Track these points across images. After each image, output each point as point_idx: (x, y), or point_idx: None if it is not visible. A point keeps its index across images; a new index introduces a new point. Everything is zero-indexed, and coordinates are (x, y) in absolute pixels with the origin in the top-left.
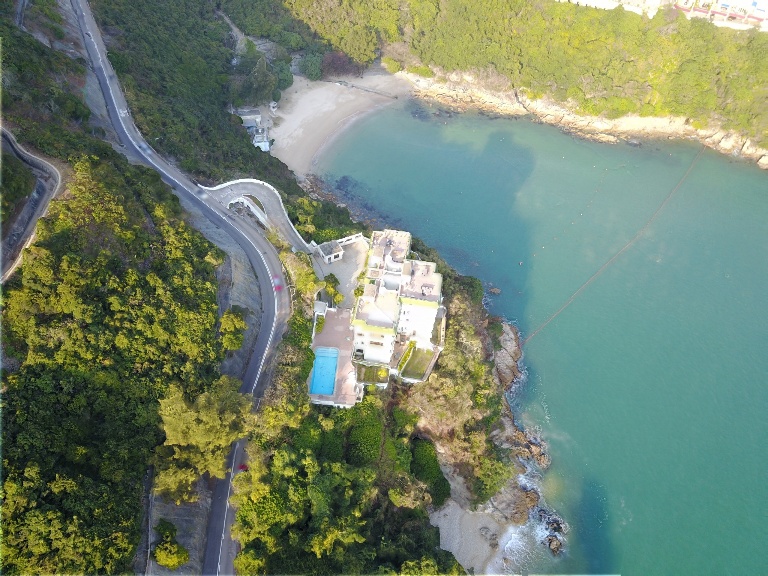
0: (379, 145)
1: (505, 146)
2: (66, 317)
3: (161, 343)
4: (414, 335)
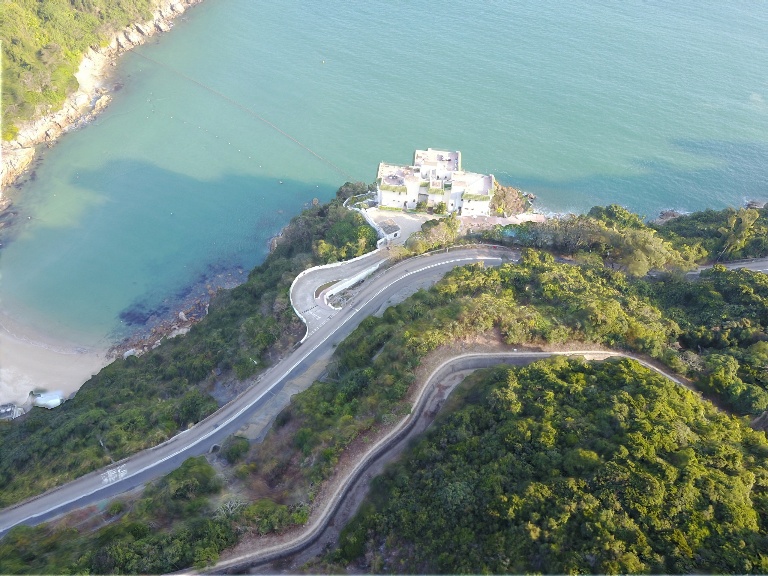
0: (58, 283)
1: (89, 175)
2: None
3: None
4: None
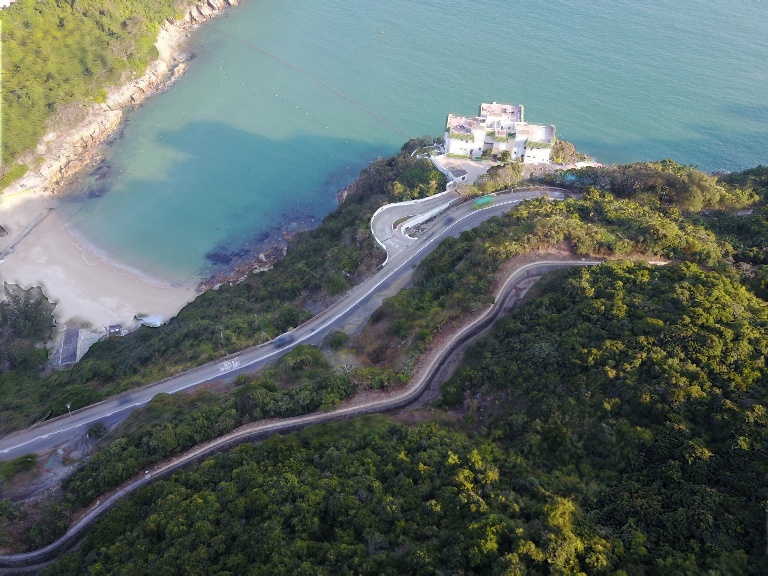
0: (150, 227)
1: (171, 135)
2: None
3: None
4: None
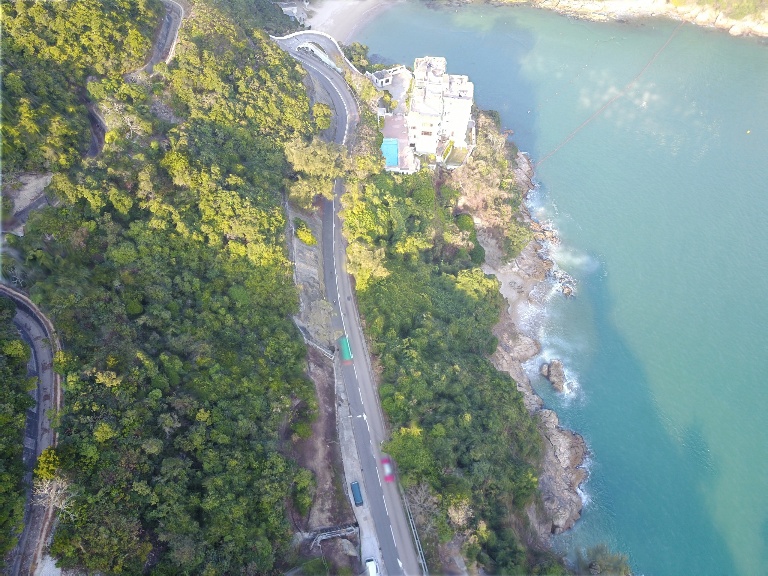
0: (400, 30)
1: (509, 28)
2: (211, 91)
3: (275, 117)
4: (452, 136)
